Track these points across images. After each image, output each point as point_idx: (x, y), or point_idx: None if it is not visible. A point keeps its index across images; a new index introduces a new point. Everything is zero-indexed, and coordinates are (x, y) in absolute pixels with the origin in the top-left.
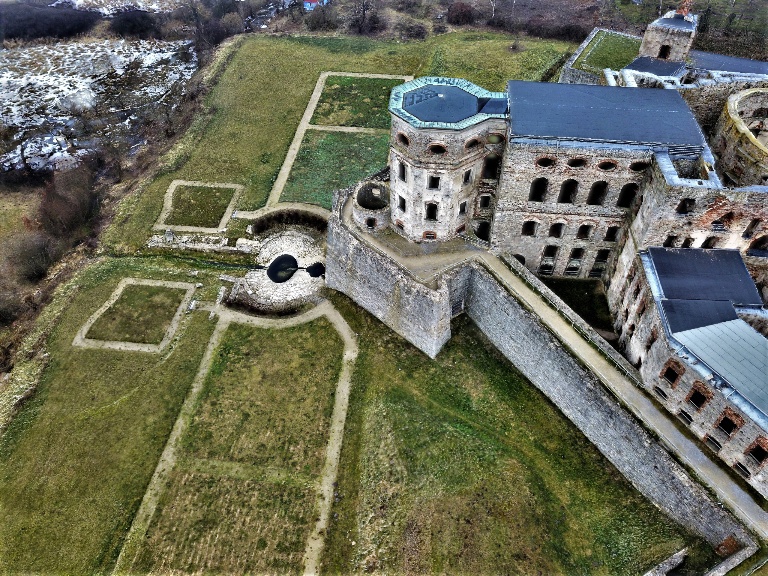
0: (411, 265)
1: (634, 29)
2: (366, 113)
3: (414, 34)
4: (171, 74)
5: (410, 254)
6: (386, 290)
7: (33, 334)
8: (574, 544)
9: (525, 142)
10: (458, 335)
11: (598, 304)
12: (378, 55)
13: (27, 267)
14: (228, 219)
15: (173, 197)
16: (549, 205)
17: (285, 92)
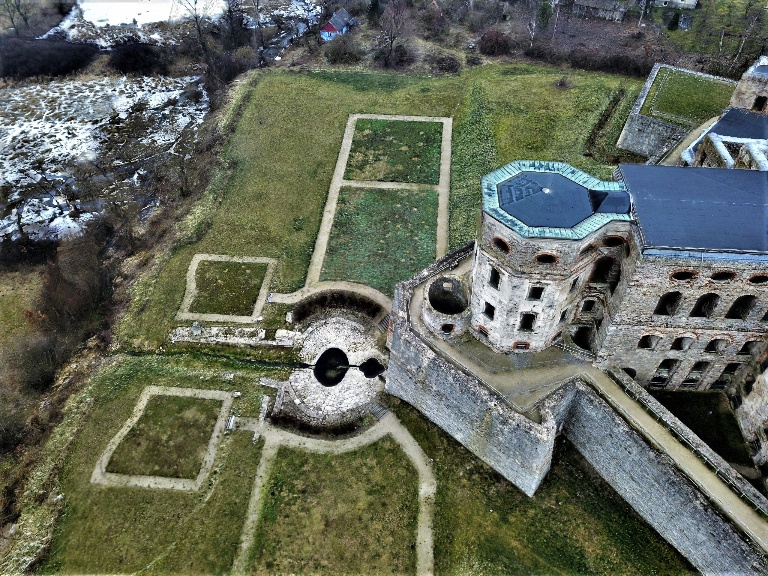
0: (502, 385)
1: (688, 59)
2: (405, 164)
3: (446, 67)
4: (180, 117)
5: (499, 370)
6: (471, 414)
7: (42, 467)
8: None
9: (661, 254)
10: (558, 465)
11: (727, 427)
12: (410, 93)
13: (30, 371)
14: (263, 304)
15: (196, 276)
16: (678, 319)
17: (312, 140)
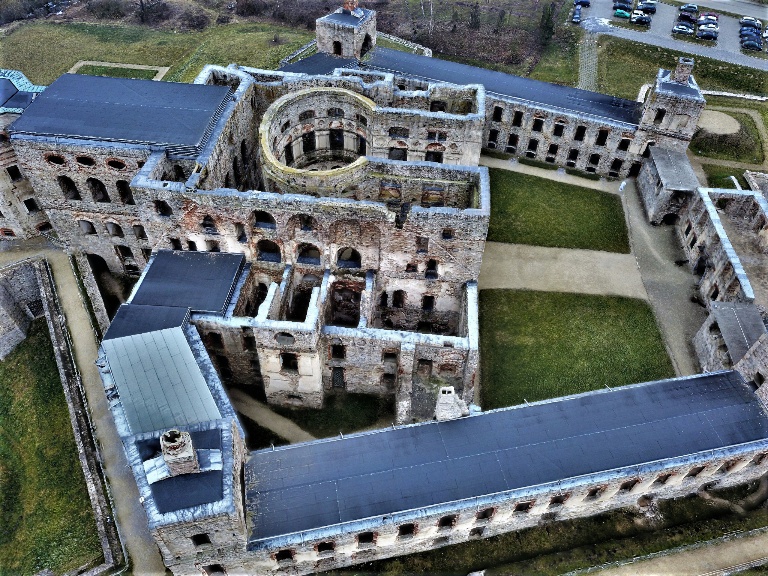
0: None
1: (410, 24)
2: None
3: (195, 24)
4: None
5: None
6: None
7: None
8: (6, 556)
9: (25, 138)
10: (34, 336)
11: None
12: (146, 45)
13: None
14: None
15: None
16: (89, 204)
17: None
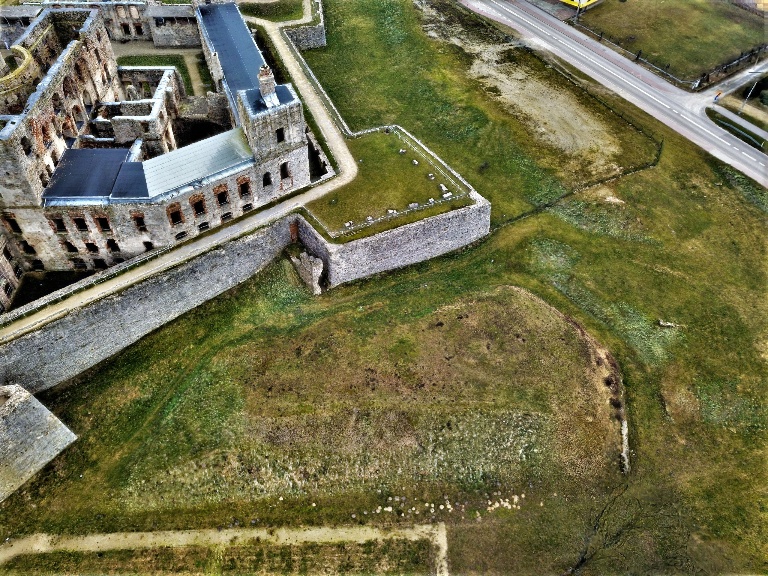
0: None
1: None
2: None
3: None
4: None
5: None
6: None
7: None
8: (285, 323)
9: None
10: (52, 410)
11: (57, 278)
12: None
13: None
14: None
15: None
16: None
17: None
